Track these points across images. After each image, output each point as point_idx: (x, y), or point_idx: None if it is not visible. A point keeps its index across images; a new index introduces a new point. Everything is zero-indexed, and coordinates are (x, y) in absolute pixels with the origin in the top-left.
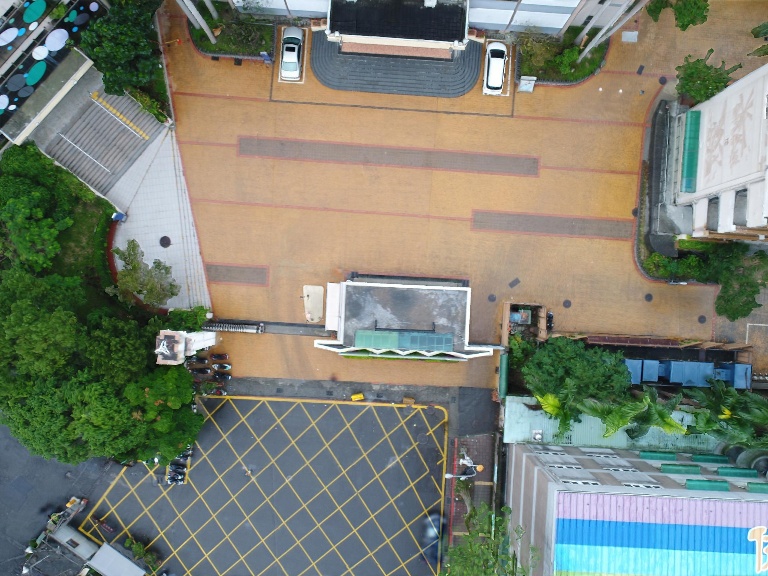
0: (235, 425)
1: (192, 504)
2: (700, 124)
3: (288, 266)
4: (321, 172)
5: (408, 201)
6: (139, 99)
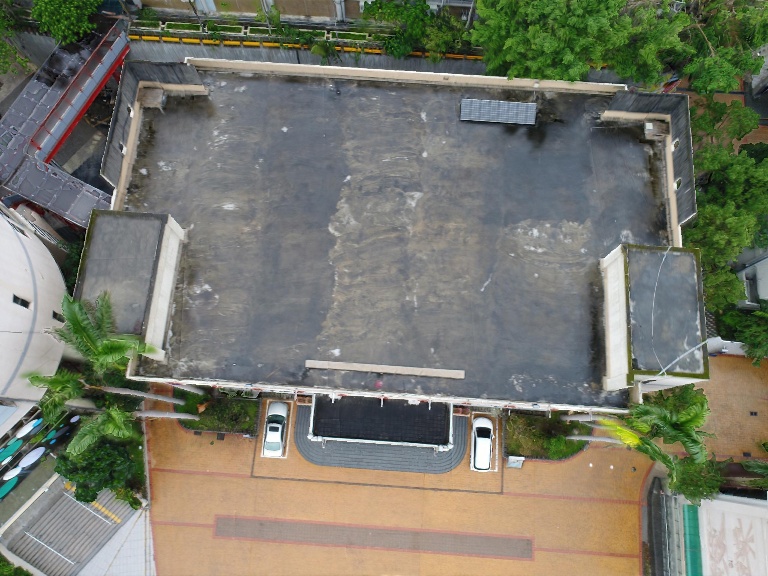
0: None
1: None
2: (699, 520)
3: None
4: (301, 555)
5: None
6: (113, 490)
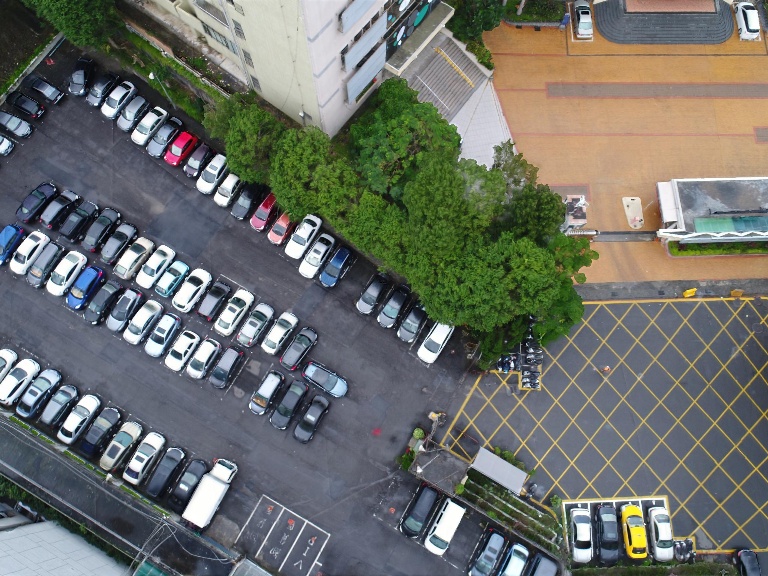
0: (579, 329)
1: (549, 410)
2: None
3: (605, 183)
4: (620, 106)
5: (698, 124)
6: (477, 48)
